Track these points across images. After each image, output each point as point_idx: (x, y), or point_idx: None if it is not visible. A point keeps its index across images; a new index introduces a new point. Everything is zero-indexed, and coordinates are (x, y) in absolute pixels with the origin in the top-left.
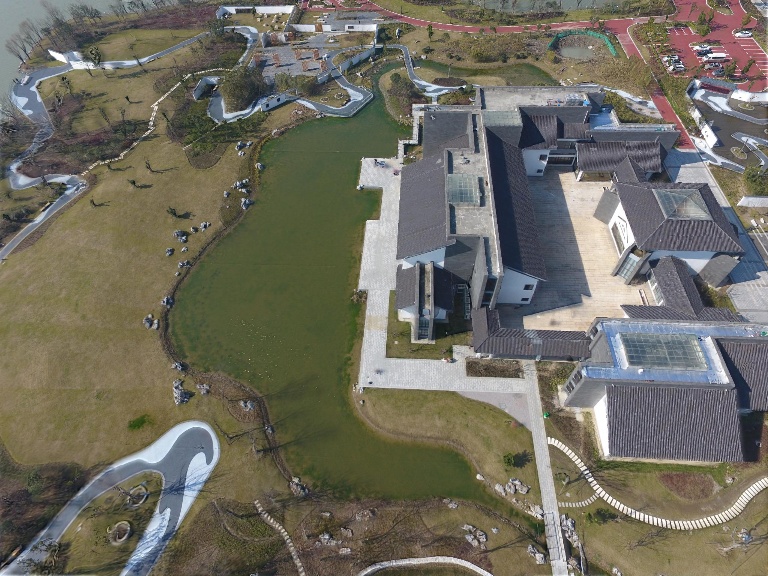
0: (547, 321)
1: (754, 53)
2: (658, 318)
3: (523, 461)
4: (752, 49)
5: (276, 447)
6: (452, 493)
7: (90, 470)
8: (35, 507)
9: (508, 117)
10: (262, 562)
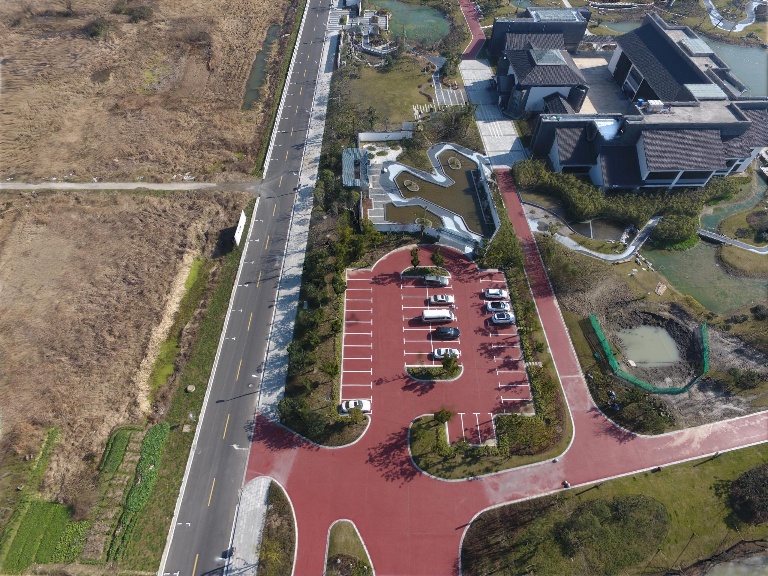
0: (595, 63)
1: (361, 345)
2: (550, 39)
3: (592, 26)
4: (359, 358)
5: (693, 30)
6: (614, 24)
7: (759, 21)
8: (765, 14)
9: (701, 91)
10: (671, 8)
